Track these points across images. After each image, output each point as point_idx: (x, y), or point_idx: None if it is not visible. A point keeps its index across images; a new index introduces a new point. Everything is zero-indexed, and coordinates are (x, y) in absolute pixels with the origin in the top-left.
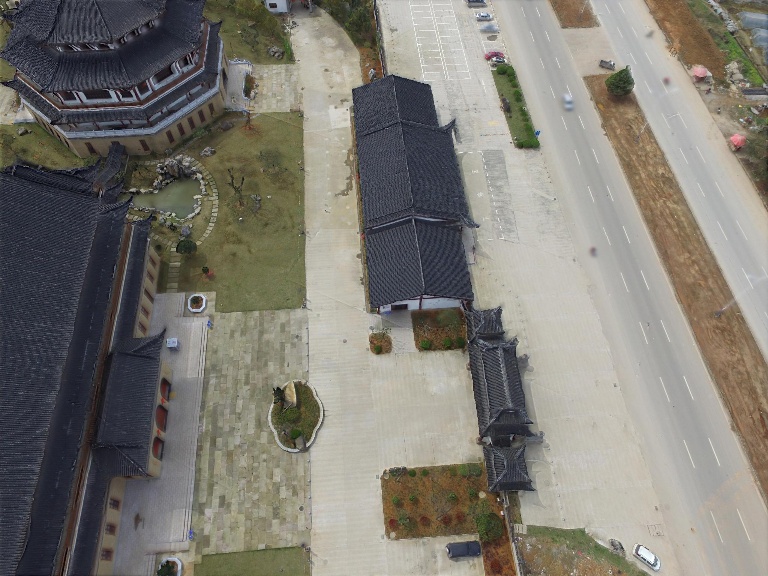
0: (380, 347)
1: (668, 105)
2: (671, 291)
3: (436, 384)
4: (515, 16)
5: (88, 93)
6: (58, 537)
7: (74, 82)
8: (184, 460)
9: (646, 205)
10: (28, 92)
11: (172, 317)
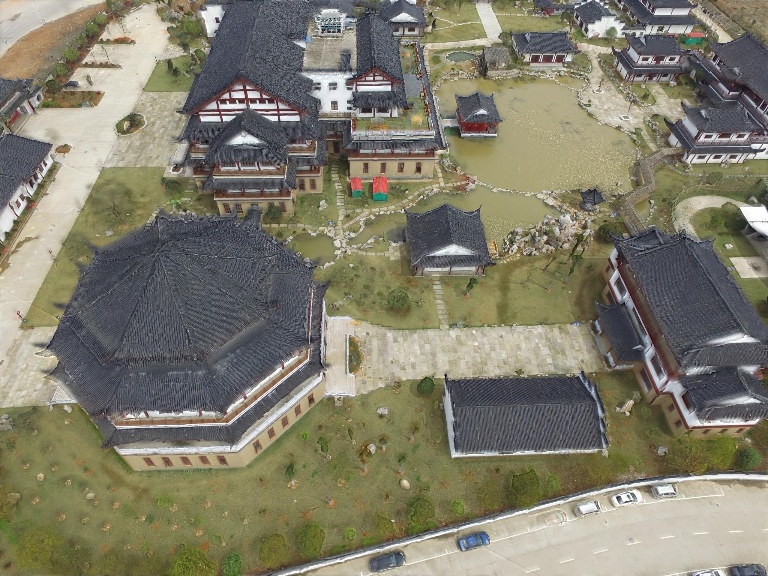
0: (64, 146)
1: None
2: None
3: (42, 133)
4: None
5: None
6: None
7: None
8: None
9: None
10: None
11: None
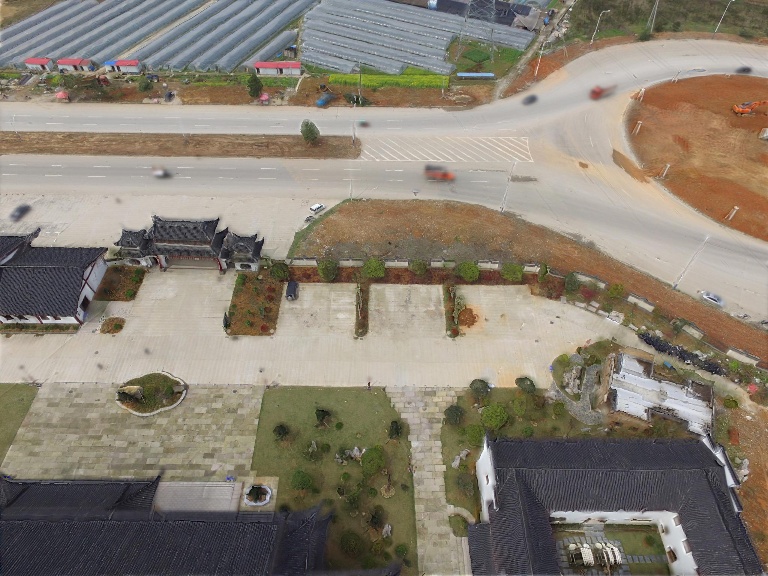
0: (116, 325)
1: (1, 118)
2: (159, 158)
3: (168, 292)
4: None
5: None
6: None
7: None
8: (157, 492)
9: (84, 151)
10: None
11: None
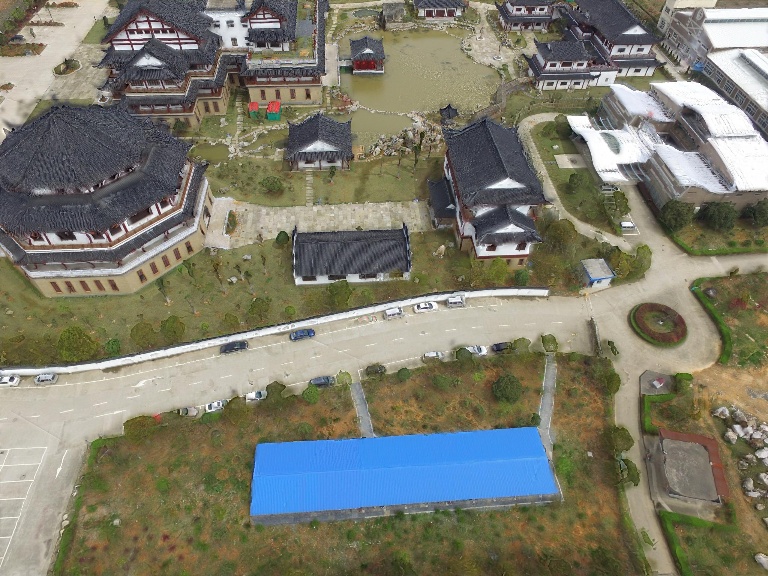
0: (8, 84)
1: None
2: None
3: None
4: None
5: None
6: None
7: None
8: None
9: None
10: None
11: None
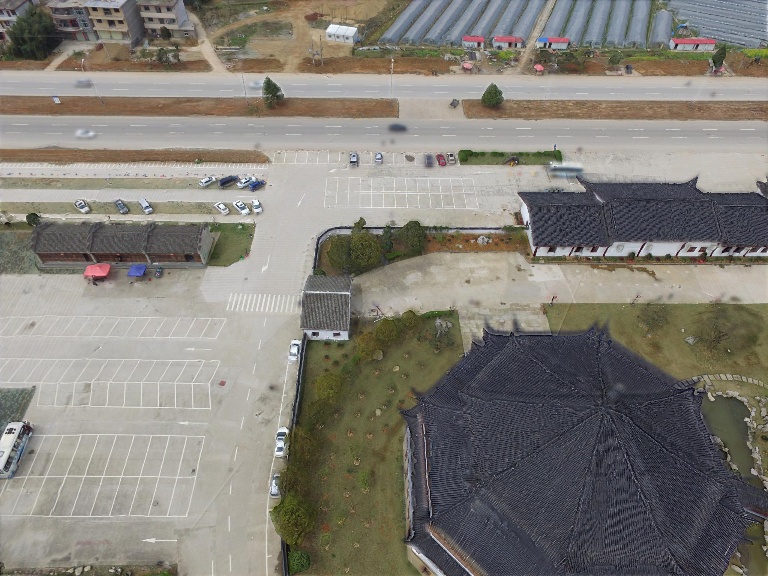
0: None
1: (498, 88)
2: (678, 121)
3: None
4: (377, 140)
5: None
6: None
7: None
8: None
9: (607, 116)
10: None
11: None
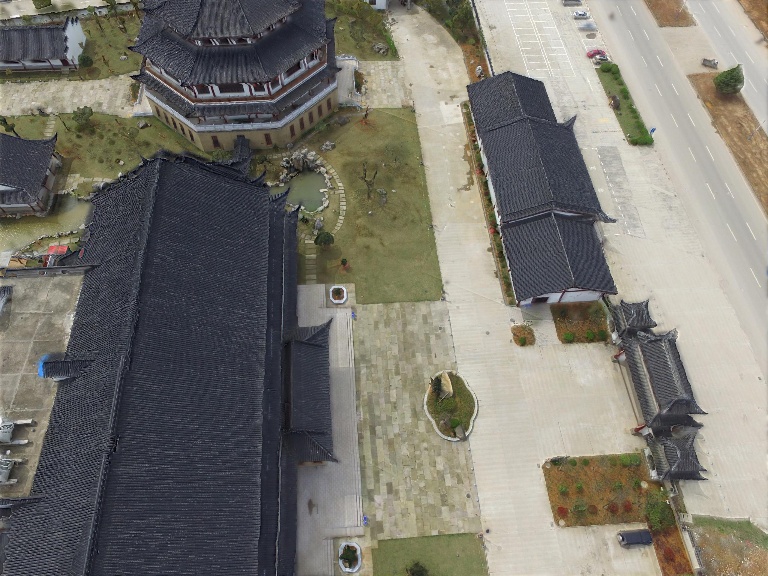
0: (524, 339)
1: None
2: None
3: (584, 376)
4: (611, 15)
5: (223, 87)
6: (277, 518)
7: (212, 76)
8: (348, 447)
9: (767, 202)
10: (157, 86)
11: (316, 308)
